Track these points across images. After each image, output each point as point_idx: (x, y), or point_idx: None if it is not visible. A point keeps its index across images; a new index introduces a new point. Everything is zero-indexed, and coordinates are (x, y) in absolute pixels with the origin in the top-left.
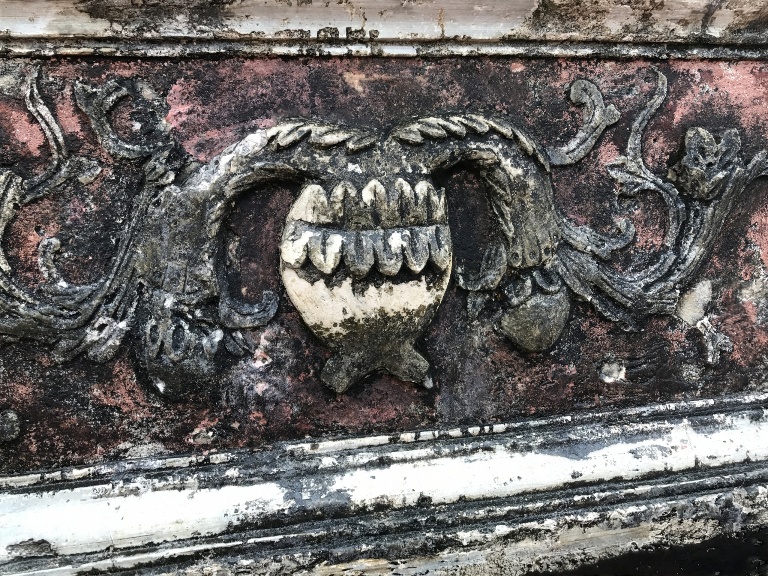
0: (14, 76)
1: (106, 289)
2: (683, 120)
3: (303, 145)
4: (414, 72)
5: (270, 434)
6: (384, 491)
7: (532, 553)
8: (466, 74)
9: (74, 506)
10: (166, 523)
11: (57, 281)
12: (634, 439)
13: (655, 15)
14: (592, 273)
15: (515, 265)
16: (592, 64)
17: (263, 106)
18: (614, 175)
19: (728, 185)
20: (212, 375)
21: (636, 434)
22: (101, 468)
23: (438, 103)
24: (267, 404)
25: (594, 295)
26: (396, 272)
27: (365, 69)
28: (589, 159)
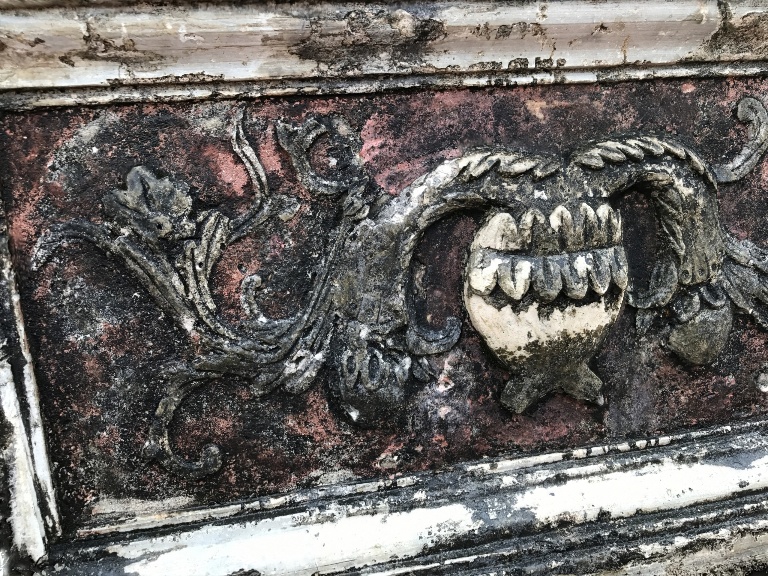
0: (221, 118)
1: (304, 323)
2: None
3: (492, 174)
4: (592, 97)
5: (451, 456)
6: (566, 508)
7: (708, 562)
8: (640, 97)
9: (276, 535)
10: (366, 548)
11: (258, 317)
12: None
13: None
14: (754, 286)
15: (685, 282)
16: (758, 82)
17: (450, 137)
18: None
19: None
20: (401, 402)
21: None
22: (296, 496)
23: (613, 126)
24: (449, 427)
25: (755, 307)
26: (583, 296)
27: (546, 96)
28: (752, 175)
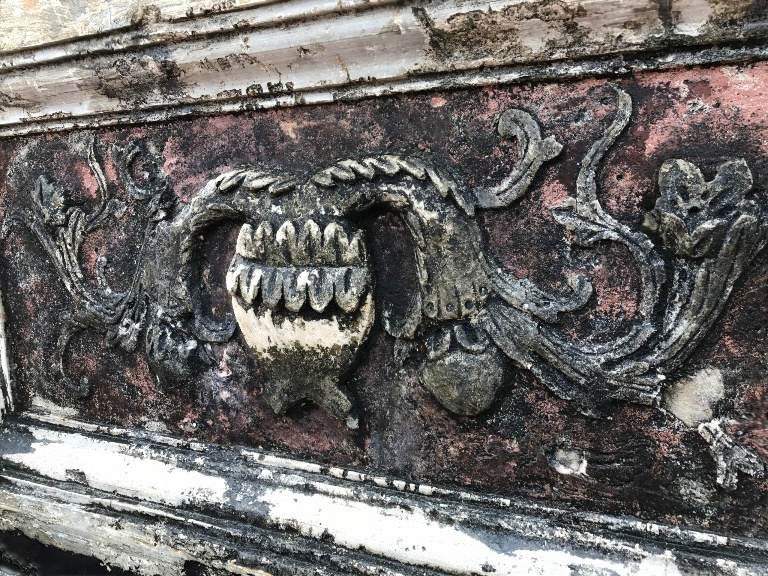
0: (84, 142)
1: (128, 297)
2: (659, 150)
3: (241, 189)
4: (338, 116)
5: (233, 437)
6: (297, 516)
7: None
8: (386, 114)
9: (107, 454)
10: (147, 486)
11: (106, 288)
12: (584, 553)
13: (583, 23)
14: (529, 336)
15: (431, 316)
16: (527, 89)
17: (223, 155)
18: (560, 220)
19: (725, 239)
20: (188, 376)
21: (589, 547)
22: (129, 432)
23: (361, 145)
24: (230, 410)
25: (535, 363)
26: (297, 309)
27: (296, 117)
28: (528, 201)
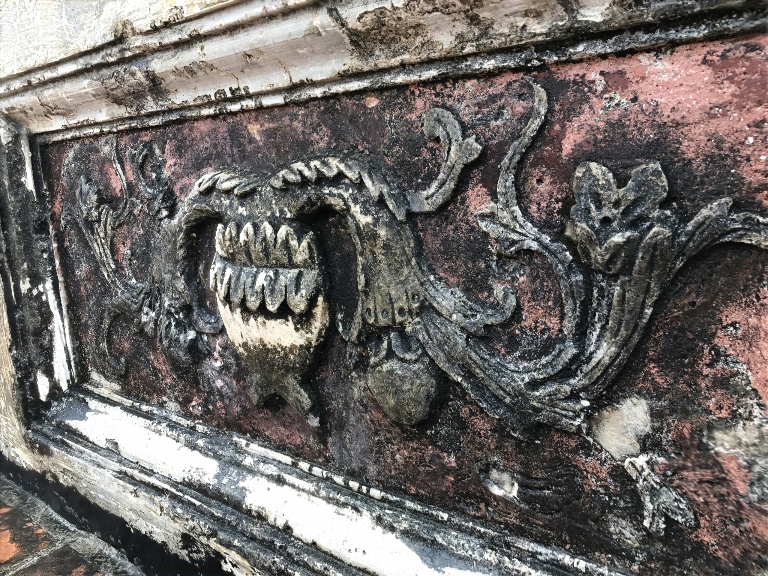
0: (110, 146)
1: (146, 288)
2: (575, 151)
3: (216, 190)
4: (291, 118)
5: (228, 423)
6: (266, 504)
7: None
8: (329, 115)
9: (136, 428)
10: (159, 460)
11: (132, 278)
12: None
13: (484, 14)
14: (458, 349)
15: (369, 321)
16: (449, 86)
17: (207, 157)
18: (484, 227)
19: (638, 254)
20: (190, 364)
21: (514, 575)
22: (154, 409)
23: (312, 146)
24: (225, 398)
25: (465, 377)
26: (255, 309)
27: (259, 120)
28: (455, 205)
